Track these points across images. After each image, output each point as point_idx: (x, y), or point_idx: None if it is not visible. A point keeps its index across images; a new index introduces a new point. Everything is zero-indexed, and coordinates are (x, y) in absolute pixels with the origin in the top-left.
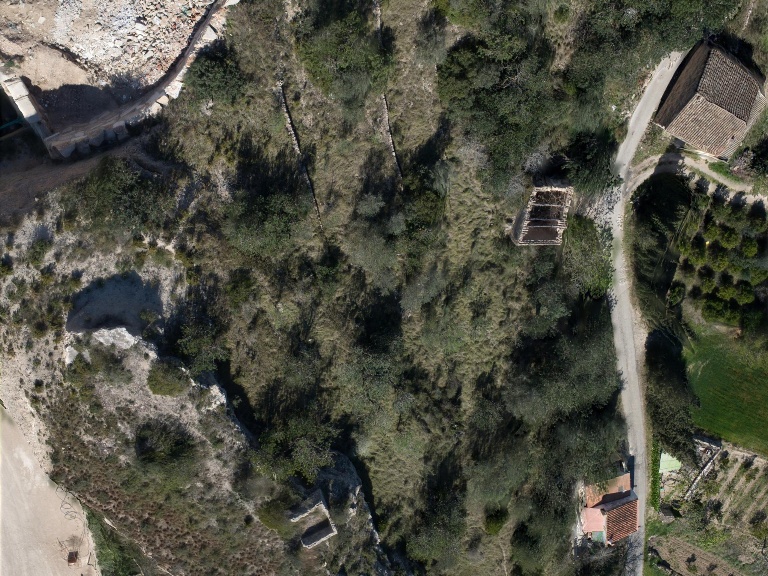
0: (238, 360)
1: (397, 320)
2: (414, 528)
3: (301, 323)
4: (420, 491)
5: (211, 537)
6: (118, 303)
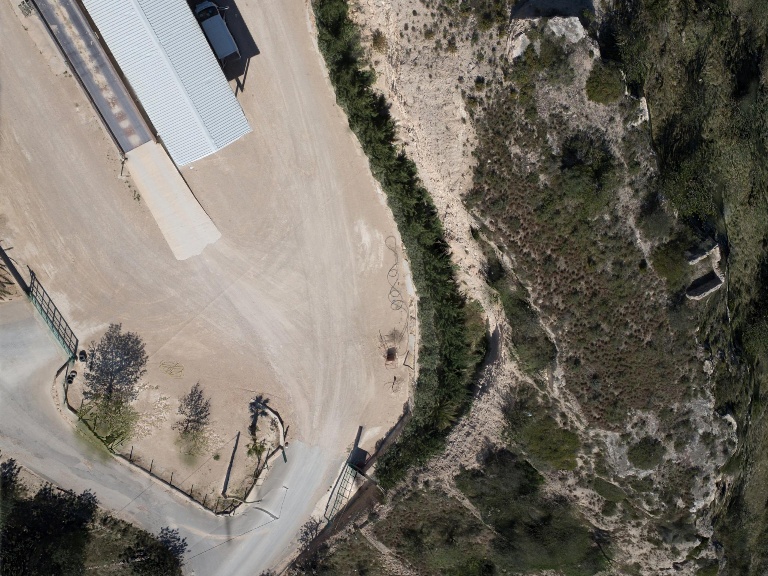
0: (648, 85)
1: (756, 83)
2: (749, 318)
3: (696, 59)
4: (755, 278)
5: (603, 284)
6: (558, 1)
